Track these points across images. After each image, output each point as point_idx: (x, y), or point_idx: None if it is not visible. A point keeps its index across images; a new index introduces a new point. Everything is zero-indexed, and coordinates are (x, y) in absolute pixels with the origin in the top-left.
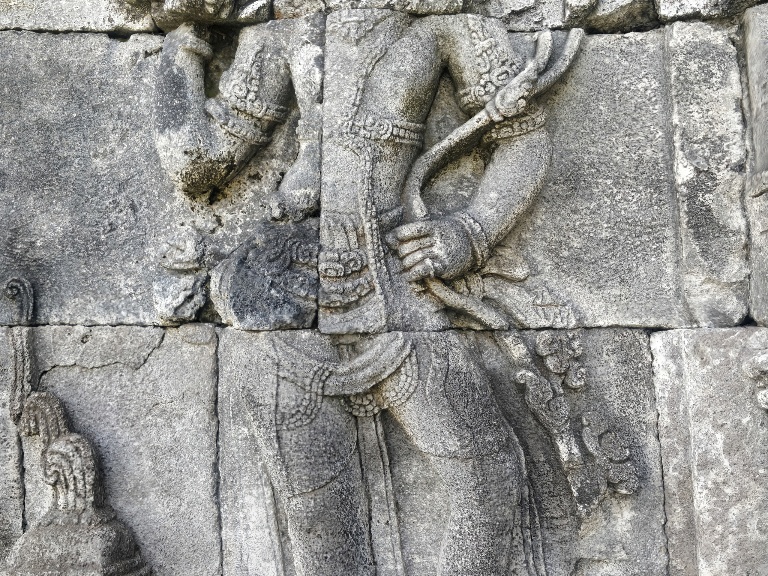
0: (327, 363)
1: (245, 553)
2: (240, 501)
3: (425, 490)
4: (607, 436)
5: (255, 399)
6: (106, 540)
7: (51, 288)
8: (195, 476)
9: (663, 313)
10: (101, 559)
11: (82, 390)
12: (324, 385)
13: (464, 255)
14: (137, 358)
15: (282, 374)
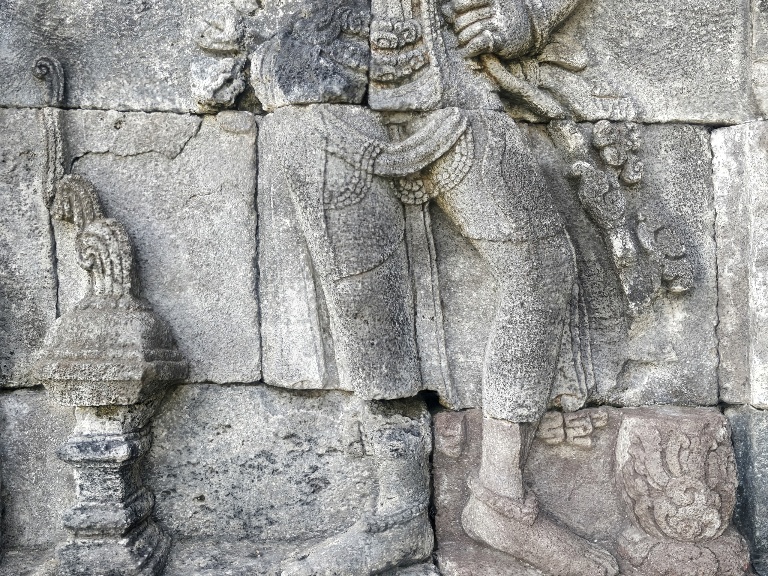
0: (378, 140)
1: (286, 348)
2: (281, 295)
3: (471, 288)
4: (663, 231)
5: (301, 178)
6: (145, 324)
7: (82, 69)
8: (234, 270)
9: (726, 107)
10: (141, 341)
11: (116, 179)
12: (374, 163)
13: (523, 32)
14: (173, 147)
15: (331, 149)
